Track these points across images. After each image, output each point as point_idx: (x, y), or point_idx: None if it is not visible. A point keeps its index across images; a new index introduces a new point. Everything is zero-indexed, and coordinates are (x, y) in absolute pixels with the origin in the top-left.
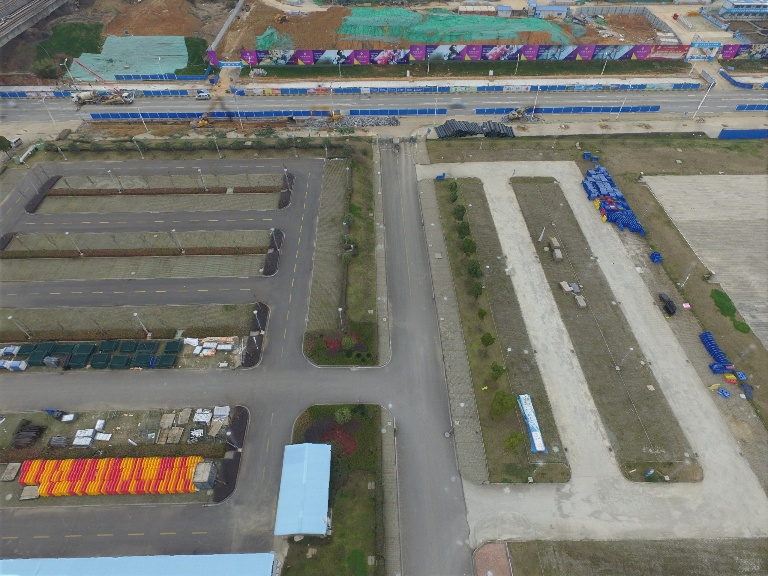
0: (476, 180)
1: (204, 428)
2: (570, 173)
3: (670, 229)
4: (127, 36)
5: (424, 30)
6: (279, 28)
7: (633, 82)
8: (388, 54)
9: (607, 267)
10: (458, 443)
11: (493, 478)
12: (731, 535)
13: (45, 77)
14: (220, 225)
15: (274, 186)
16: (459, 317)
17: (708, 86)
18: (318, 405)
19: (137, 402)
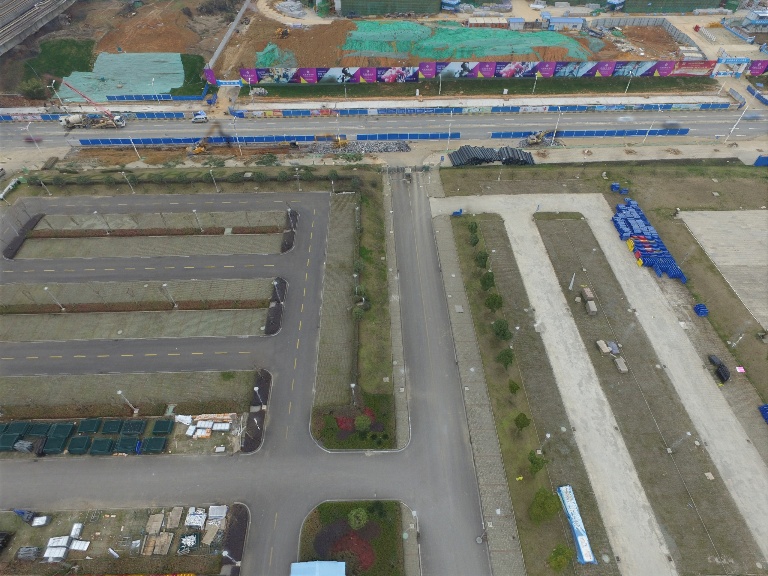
0: (496, 216)
1: (197, 534)
2: (598, 208)
3: (714, 276)
4: (120, 53)
5: (434, 45)
6: (280, 44)
7: (657, 101)
8: (396, 72)
9: (647, 322)
10: (492, 552)
11: None
12: None
13: (32, 98)
14: (217, 272)
15: (276, 225)
16: (486, 386)
17: (738, 106)
18: (329, 503)
19: (120, 498)
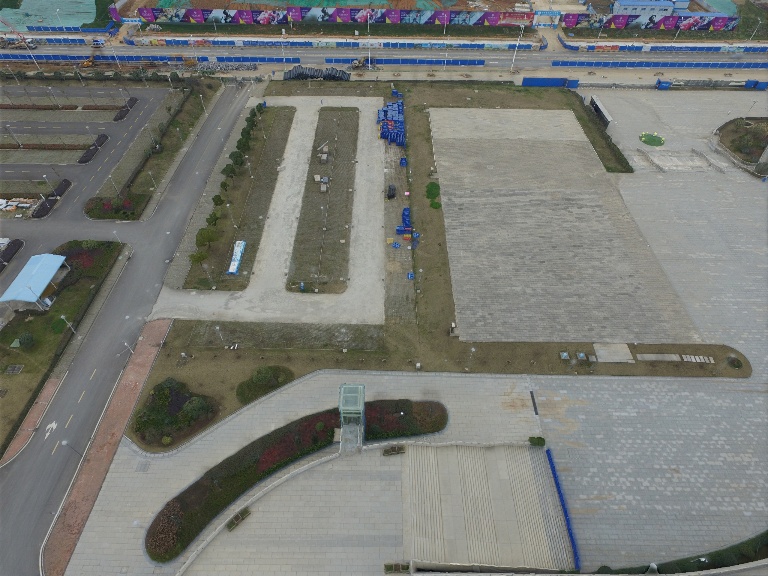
0: (292, 108)
1: None
2: (374, 105)
3: (426, 143)
4: None
5: None
6: None
7: (479, 43)
8: (268, 15)
9: (361, 168)
10: (172, 266)
11: (186, 286)
12: (342, 322)
13: None
14: (61, 131)
15: None
16: (219, 194)
17: (539, 47)
18: (77, 240)
19: None
